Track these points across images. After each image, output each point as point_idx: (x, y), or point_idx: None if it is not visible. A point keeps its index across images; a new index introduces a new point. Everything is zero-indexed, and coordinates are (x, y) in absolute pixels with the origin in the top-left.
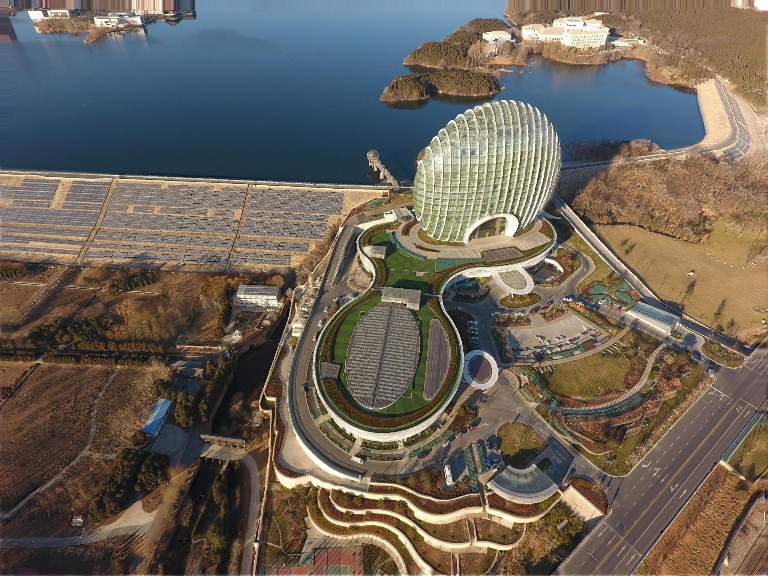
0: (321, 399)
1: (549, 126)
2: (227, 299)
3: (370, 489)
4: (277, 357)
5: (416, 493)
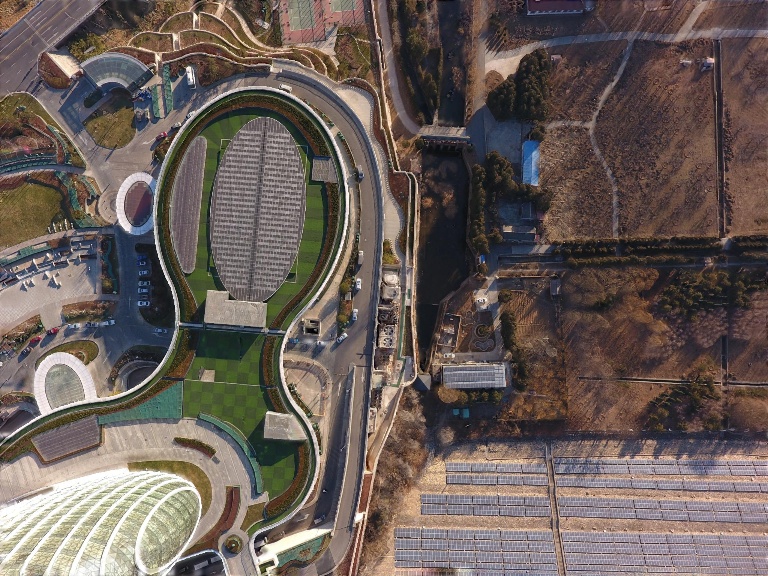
0: (327, 127)
1: None
2: (516, 358)
3: (270, 61)
4: (408, 233)
5: (224, 58)
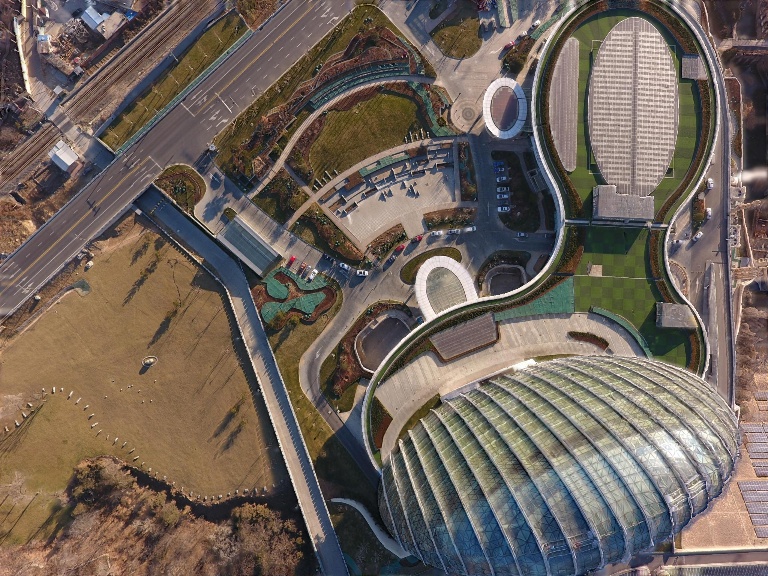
0: None
1: (457, 519)
2: None
3: None
4: None
5: None
